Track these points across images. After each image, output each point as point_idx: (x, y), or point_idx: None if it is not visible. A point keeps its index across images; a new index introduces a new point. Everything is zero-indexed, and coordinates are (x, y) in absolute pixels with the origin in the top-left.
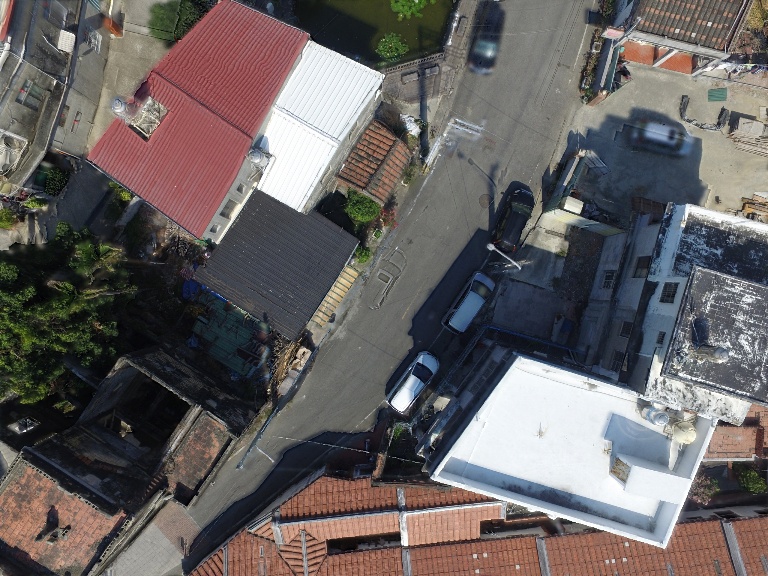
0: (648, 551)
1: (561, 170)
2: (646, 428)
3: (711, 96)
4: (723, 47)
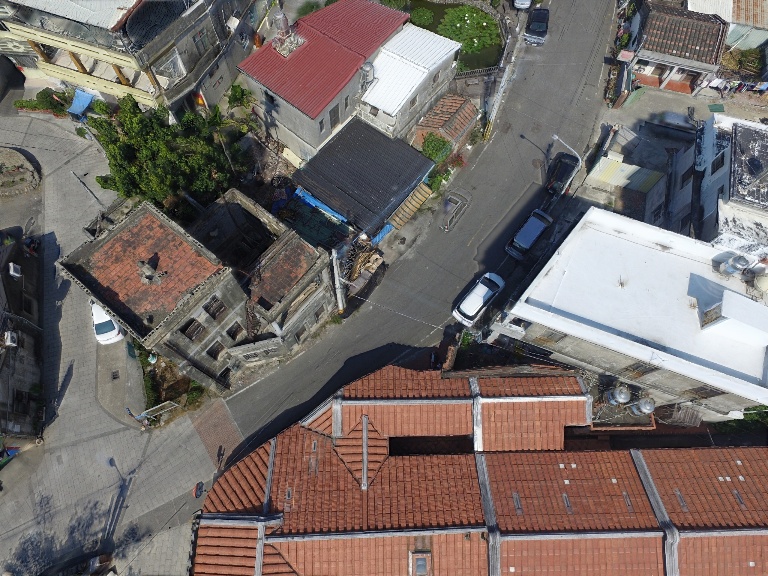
0: (767, 471)
1: (599, 147)
2: (728, 289)
3: (711, 109)
4: (712, 63)
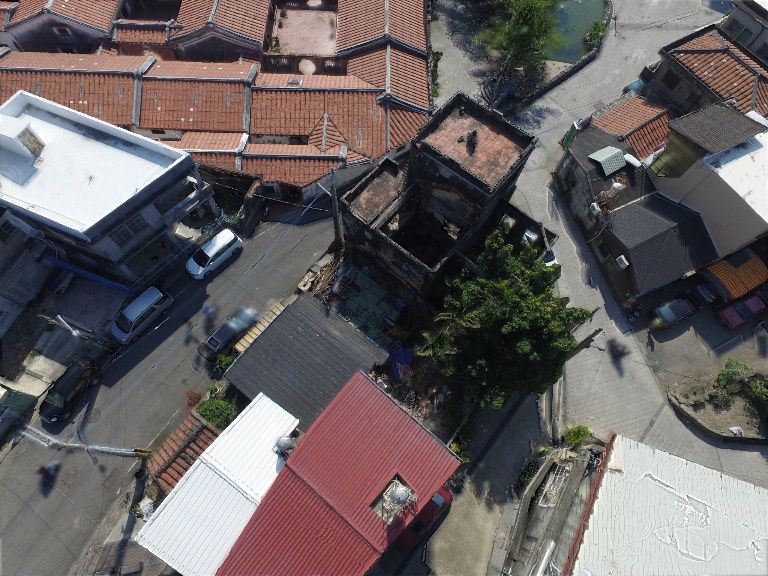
0: None
1: (0, 442)
2: None
3: None
4: None
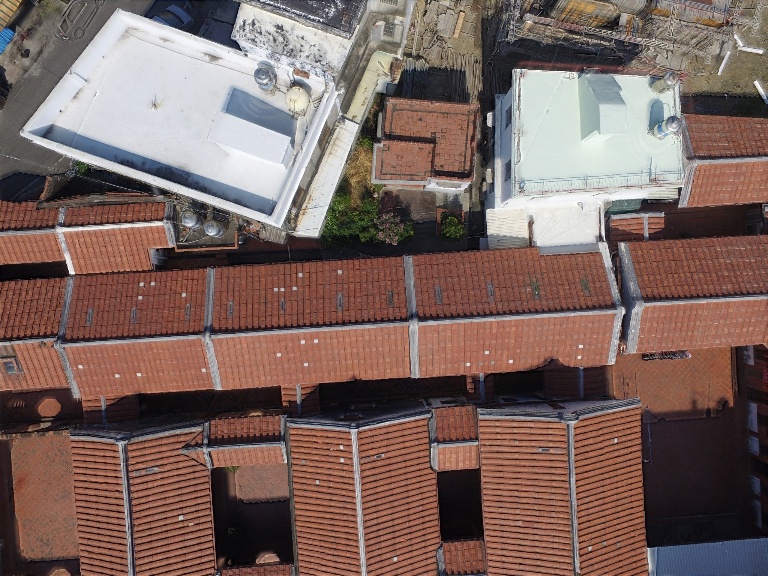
0: (321, 282)
1: None
2: (270, 106)
3: None
4: None
